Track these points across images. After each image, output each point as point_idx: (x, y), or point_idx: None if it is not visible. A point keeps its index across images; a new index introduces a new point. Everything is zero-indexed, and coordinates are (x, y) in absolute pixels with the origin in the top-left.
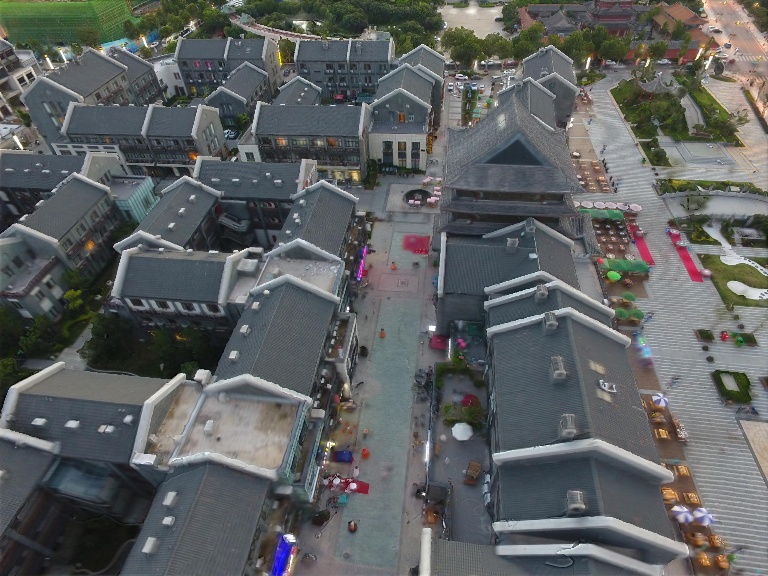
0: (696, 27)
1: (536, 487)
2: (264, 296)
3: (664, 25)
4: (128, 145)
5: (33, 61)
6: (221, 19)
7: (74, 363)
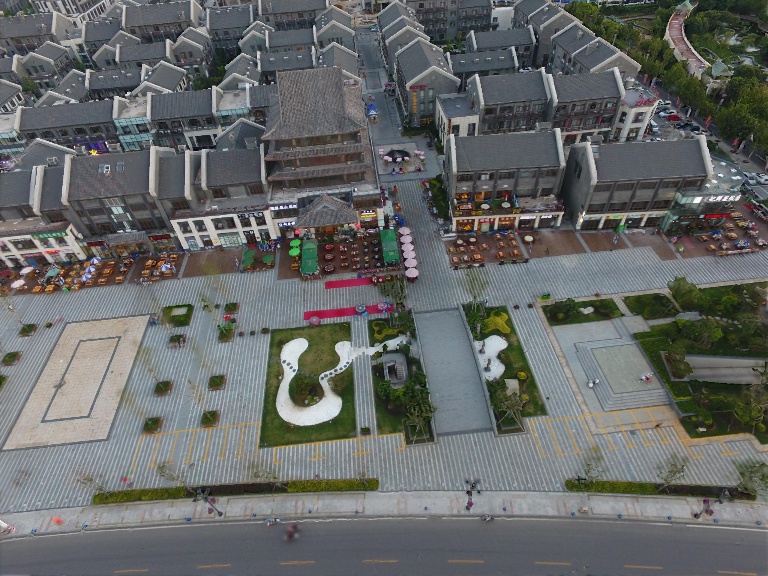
0: None
1: None
2: None
3: None
4: None
5: None
6: None
7: None
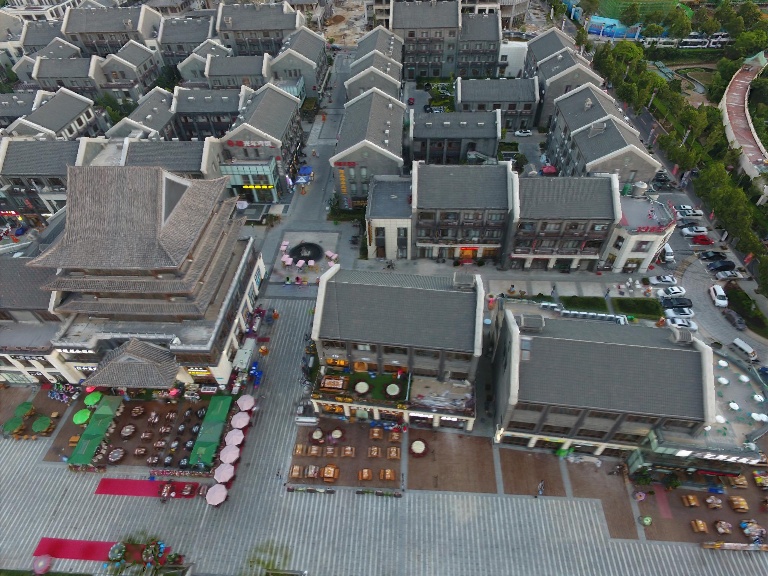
0: None
1: None
2: None
3: None
4: None
5: (512, 2)
6: (740, 48)
7: None
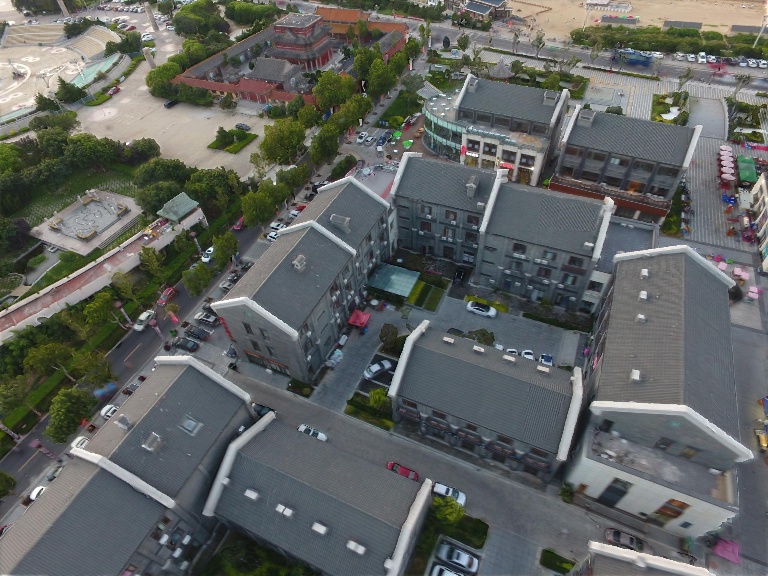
0: (368, 21)
1: None
2: None
3: (350, 29)
4: None
5: None
6: None
7: None
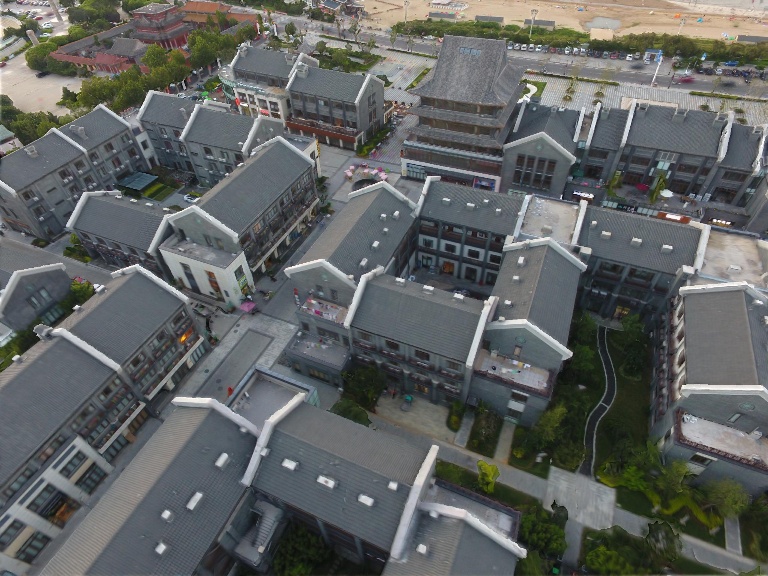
0: (228, 12)
1: (738, 150)
2: (589, 231)
3: (208, 19)
4: (92, 417)
5: None
6: None
7: (571, 490)
